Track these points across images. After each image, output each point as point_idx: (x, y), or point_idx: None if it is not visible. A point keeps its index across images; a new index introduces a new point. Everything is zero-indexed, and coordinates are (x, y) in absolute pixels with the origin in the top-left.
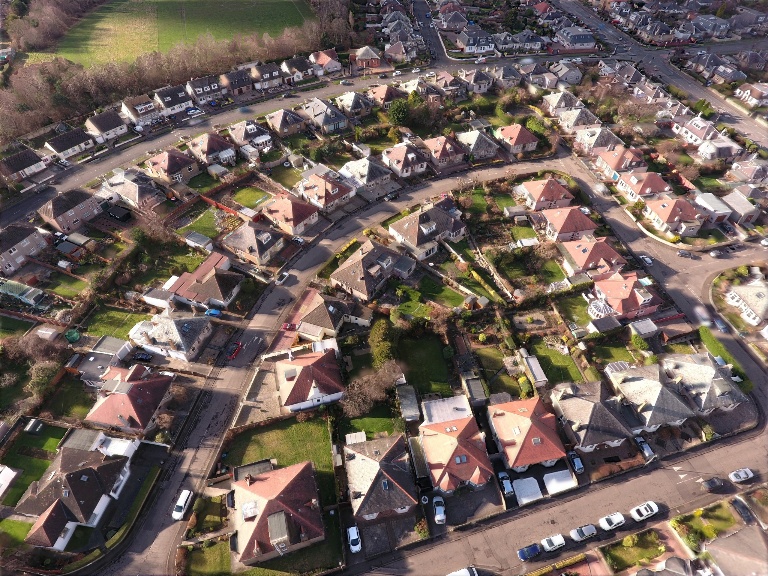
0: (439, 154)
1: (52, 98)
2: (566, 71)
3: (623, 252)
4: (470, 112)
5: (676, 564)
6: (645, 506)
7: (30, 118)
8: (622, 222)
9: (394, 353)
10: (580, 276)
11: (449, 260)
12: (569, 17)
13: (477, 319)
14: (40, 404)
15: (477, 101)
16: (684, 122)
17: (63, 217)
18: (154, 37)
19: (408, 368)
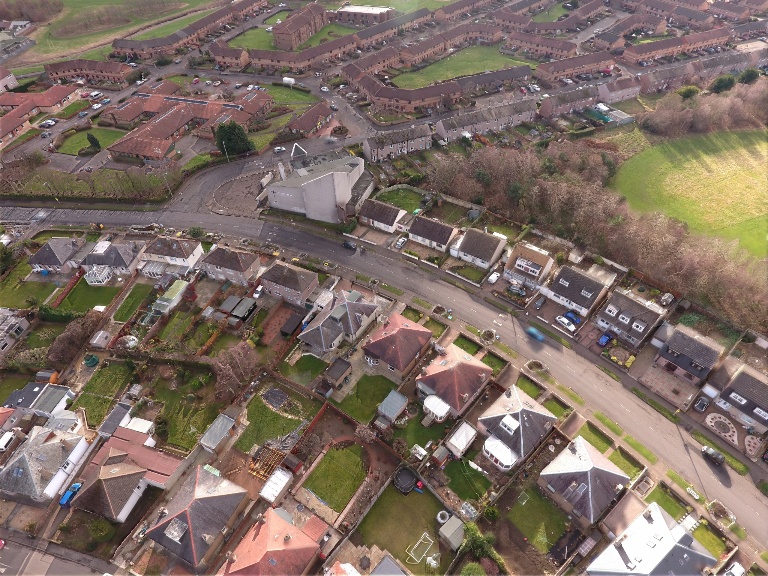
0: None
1: None
2: None
3: None
4: None
5: None
6: None
7: (465, 187)
8: None
9: None
10: None
11: None
12: None
13: None
14: (10, 369)
15: None
16: None
17: (268, 282)
18: None
19: None
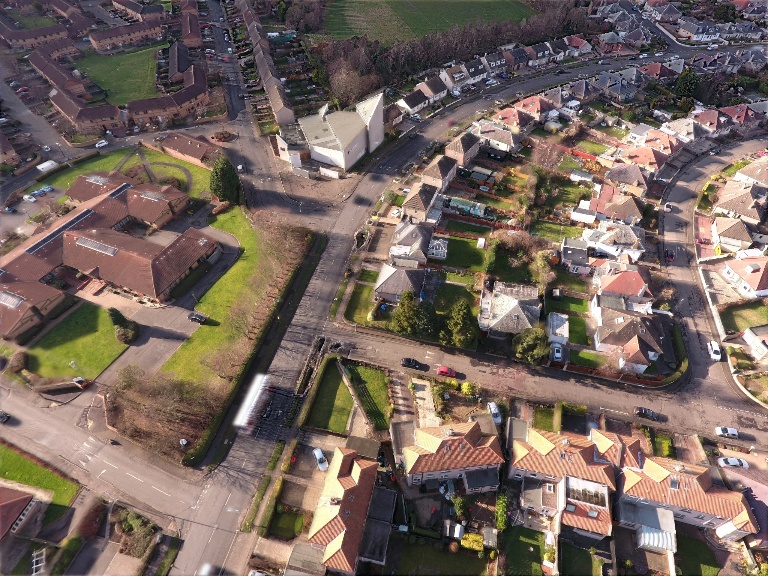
0: (743, 119)
1: (377, 67)
2: None
3: None
4: (738, 88)
5: None
6: None
7: (371, 81)
8: None
9: None
10: None
11: None
12: None
13: None
14: None
15: (740, 79)
16: None
17: (466, 153)
18: (403, 23)
19: None
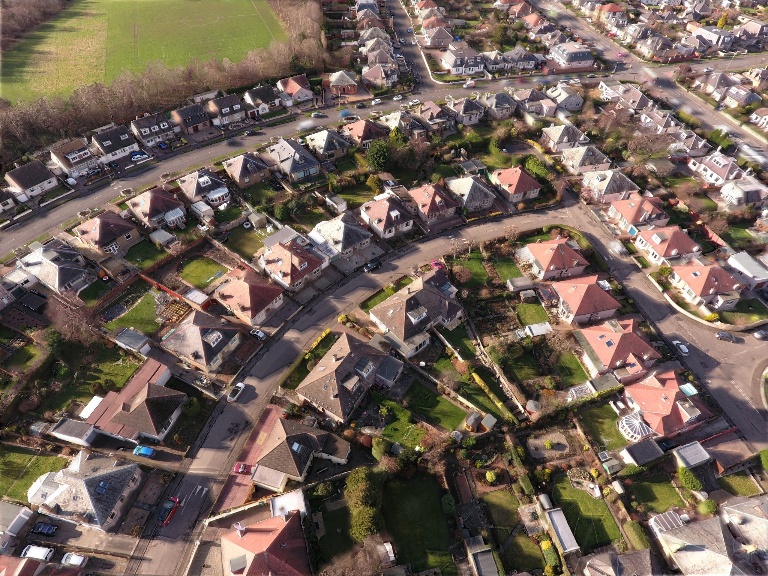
0: (427, 209)
1: None
2: (566, 97)
3: (652, 336)
4: (461, 150)
5: None
6: None
7: None
8: (646, 293)
9: (378, 523)
10: (606, 378)
11: (444, 356)
12: (562, 30)
13: (482, 445)
14: None
15: (468, 136)
16: (702, 158)
17: None
18: (101, 61)
19: (397, 529)
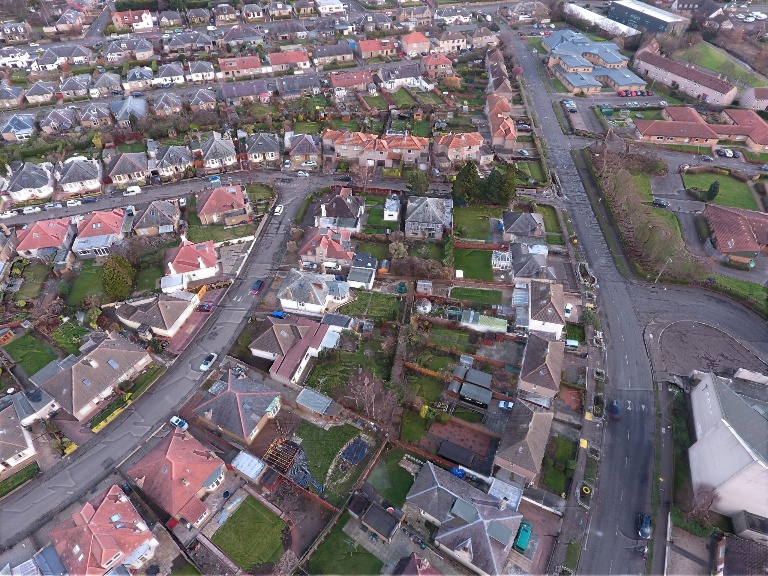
0: None
1: None
2: None
3: None
4: None
5: (16, 187)
6: (5, 213)
7: None
8: None
9: None
10: None
11: None
12: None
13: None
14: None
15: None
16: None
17: None
18: None
19: None
